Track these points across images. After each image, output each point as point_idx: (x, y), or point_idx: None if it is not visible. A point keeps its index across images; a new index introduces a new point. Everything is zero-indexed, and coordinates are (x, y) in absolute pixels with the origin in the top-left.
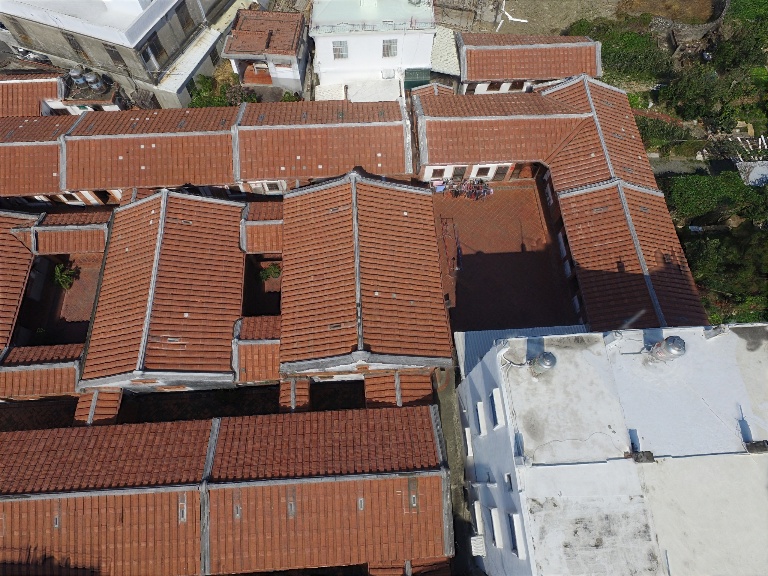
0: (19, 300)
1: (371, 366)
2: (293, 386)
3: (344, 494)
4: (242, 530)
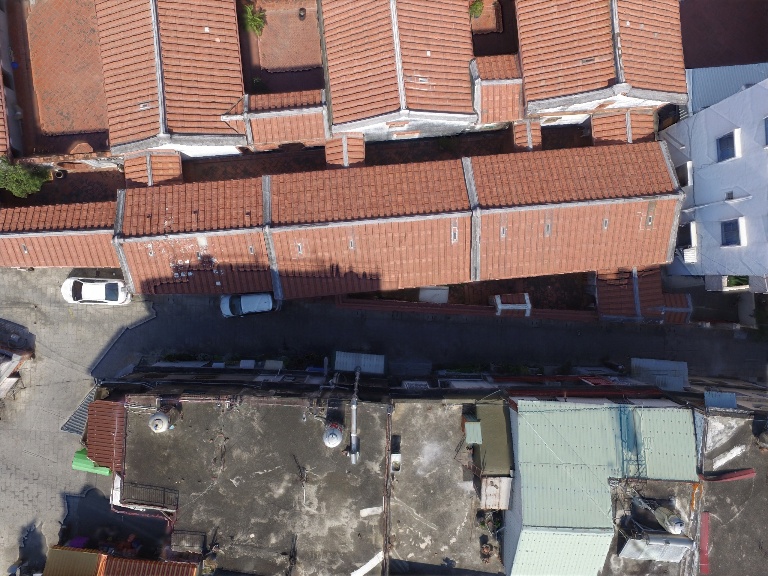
0: (237, 44)
1: (614, 103)
2: (529, 127)
3: (593, 216)
4: (506, 247)
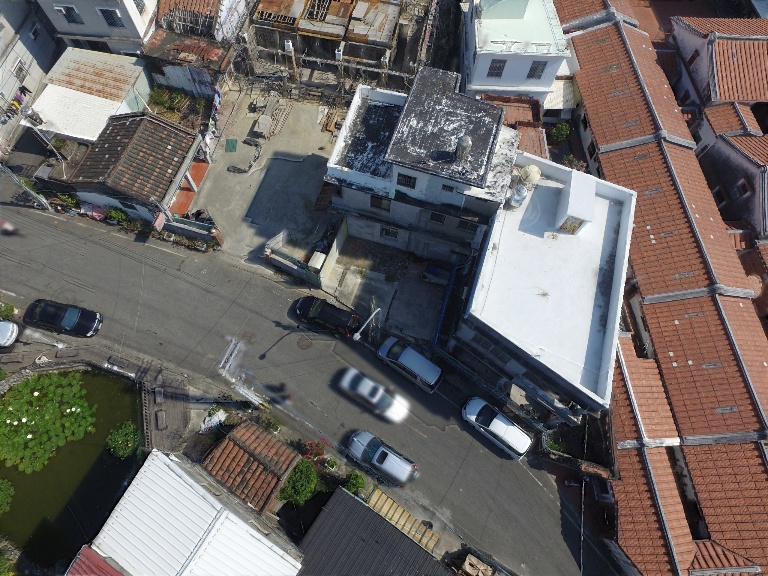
0: None
1: None
2: None
3: None
4: None
